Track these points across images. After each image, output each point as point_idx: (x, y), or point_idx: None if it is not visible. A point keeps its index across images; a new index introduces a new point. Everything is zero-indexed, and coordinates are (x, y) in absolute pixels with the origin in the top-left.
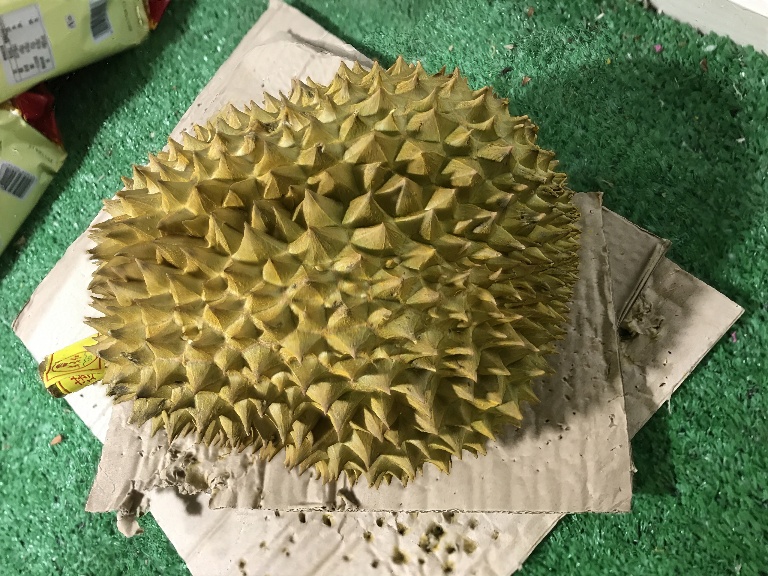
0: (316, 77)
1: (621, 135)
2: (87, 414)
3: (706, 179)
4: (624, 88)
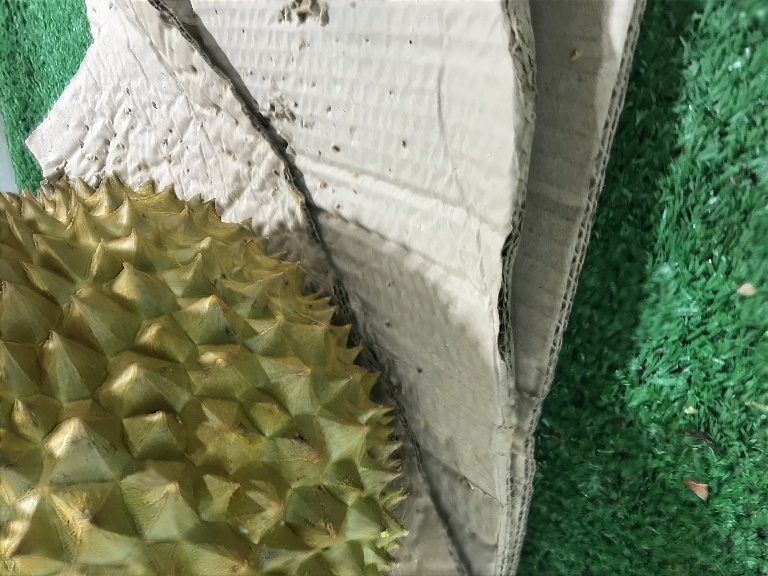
0: (467, 34)
1: None
2: (89, 6)
3: None
4: None
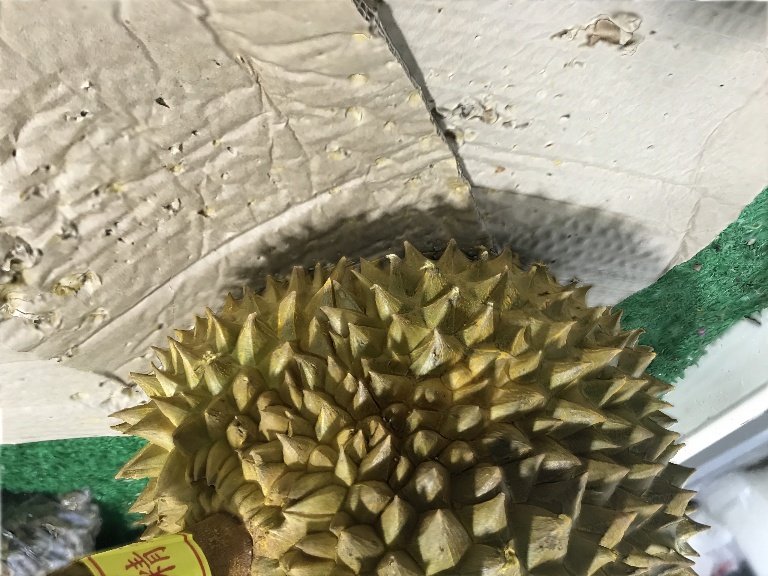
0: None
1: None
2: None
3: None
4: (666, 325)
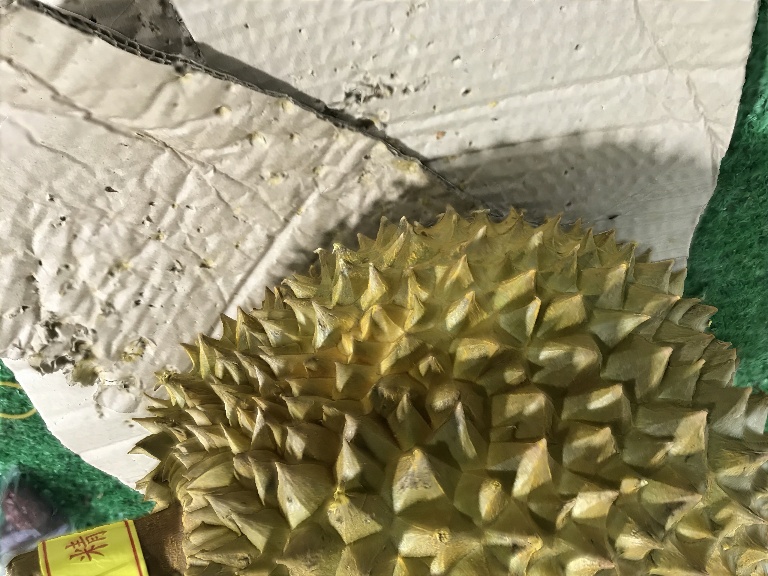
0: None
1: (766, 270)
2: None
3: (745, 338)
4: None
